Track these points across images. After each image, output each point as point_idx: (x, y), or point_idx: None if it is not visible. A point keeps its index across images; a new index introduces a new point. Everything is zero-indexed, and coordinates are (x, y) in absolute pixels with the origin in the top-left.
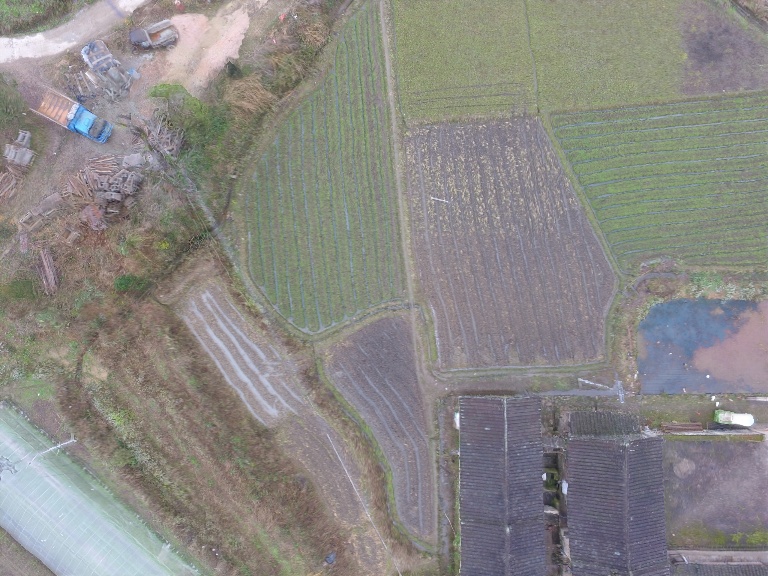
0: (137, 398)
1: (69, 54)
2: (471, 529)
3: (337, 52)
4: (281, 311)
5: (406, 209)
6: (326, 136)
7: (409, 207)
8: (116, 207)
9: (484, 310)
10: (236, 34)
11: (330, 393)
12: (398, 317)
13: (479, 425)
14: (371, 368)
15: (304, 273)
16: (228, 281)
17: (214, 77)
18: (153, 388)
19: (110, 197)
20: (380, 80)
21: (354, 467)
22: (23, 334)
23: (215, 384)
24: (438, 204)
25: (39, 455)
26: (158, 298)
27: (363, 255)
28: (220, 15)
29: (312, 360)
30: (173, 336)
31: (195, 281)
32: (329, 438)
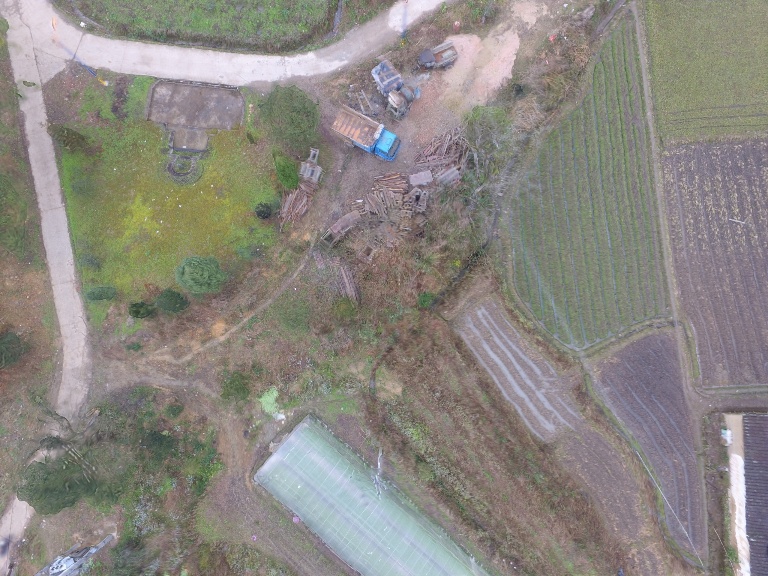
0: (431, 413)
1: (351, 73)
2: (762, 546)
3: (595, 72)
4: (547, 327)
5: (667, 227)
6: (586, 155)
7: (668, 225)
8: (408, 225)
9: (744, 328)
10: (508, 54)
11: (599, 409)
12: (664, 334)
13: (767, 443)
14: (639, 384)
15: (569, 290)
16: (501, 297)
17: (493, 97)
18: (450, 403)
19: (404, 215)
20: (638, 100)
21: (632, 482)
22: (328, 349)
23: (498, 399)
24: (696, 223)
25: (356, 469)
26: (442, 314)
27: (625, 272)
28: (491, 36)
29: (581, 376)
30: (460, 352)
31: (472, 297)
32: (639, 455)
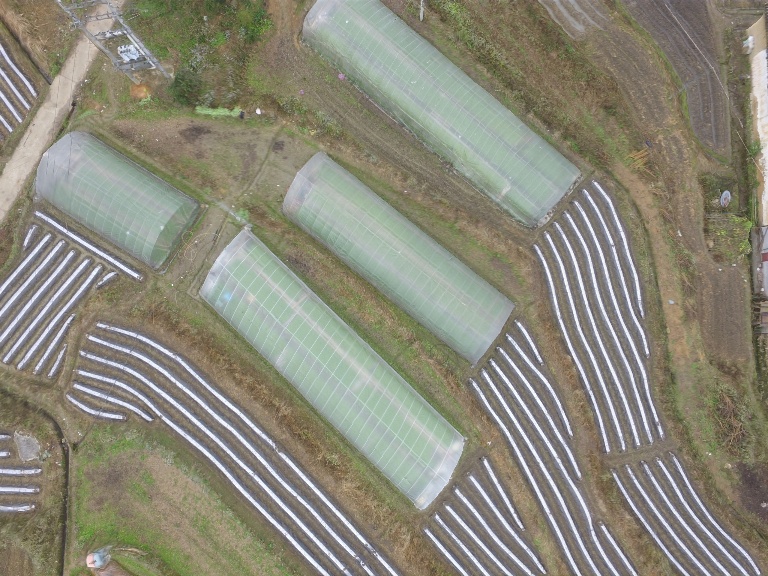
0: None
1: None
2: None
3: None
4: None
5: None
6: None
7: None
8: None
9: None
10: None
11: (626, 20)
12: None
13: None
14: None
15: None
16: None
17: None
18: None
19: None
20: None
21: (659, 76)
22: None
23: None
24: None
25: None
26: None
27: None
28: None
29: None
30: None
31: None
32: None
